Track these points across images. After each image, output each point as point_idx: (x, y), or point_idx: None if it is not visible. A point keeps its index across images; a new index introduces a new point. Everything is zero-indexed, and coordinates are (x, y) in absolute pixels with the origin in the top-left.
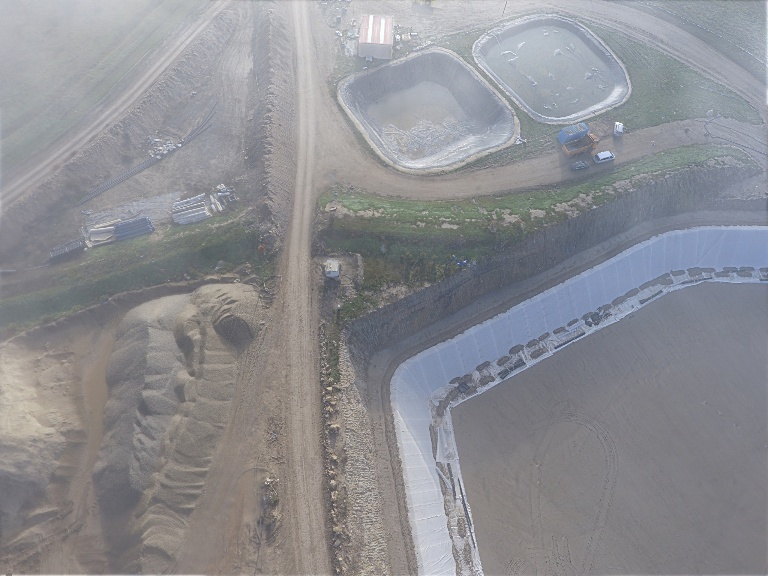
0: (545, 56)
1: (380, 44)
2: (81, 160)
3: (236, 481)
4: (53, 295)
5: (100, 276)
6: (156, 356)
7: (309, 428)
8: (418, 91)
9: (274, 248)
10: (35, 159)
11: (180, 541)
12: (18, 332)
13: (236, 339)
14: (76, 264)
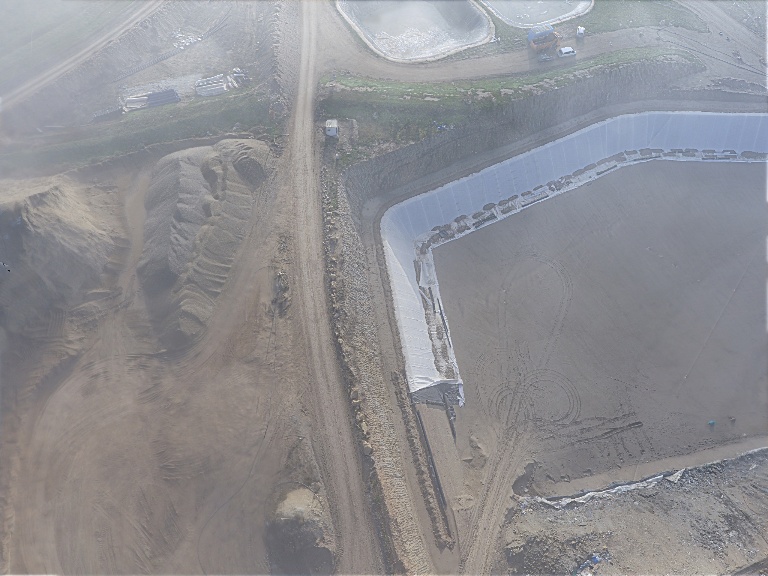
0: None
1: None
2: (117, 45)
3: (254, 275)
4: (99, 142)
5: (137, 130)
6: (187, 181)
7: (313, 240)
8: (407, 6)
9: (282, 114)
10: (76, 47)
11: (209, 314)
12: (71, 168)
13: (252, 177)
14: (116, 121)
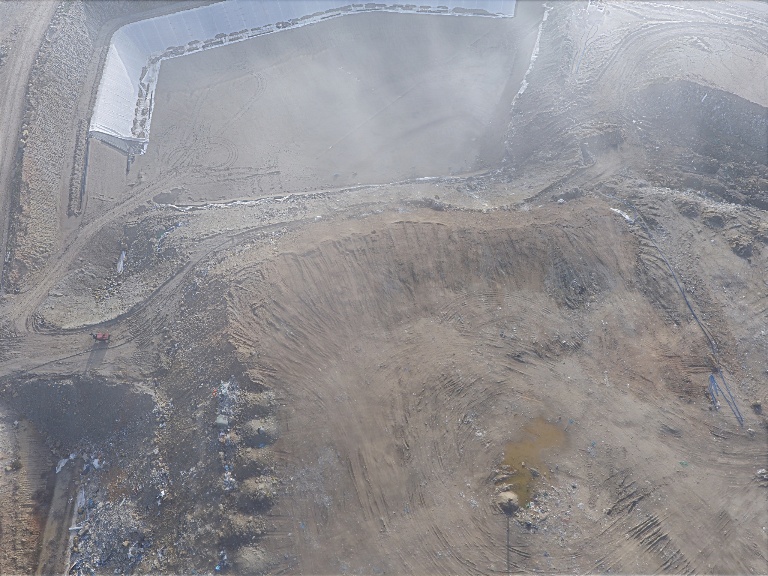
0: None
1: None
2: None
3: None
4: None
5: None
6: None
7: (39, 29)
8: None
9: None
10: None
11: None
12: None
13: None
14: None
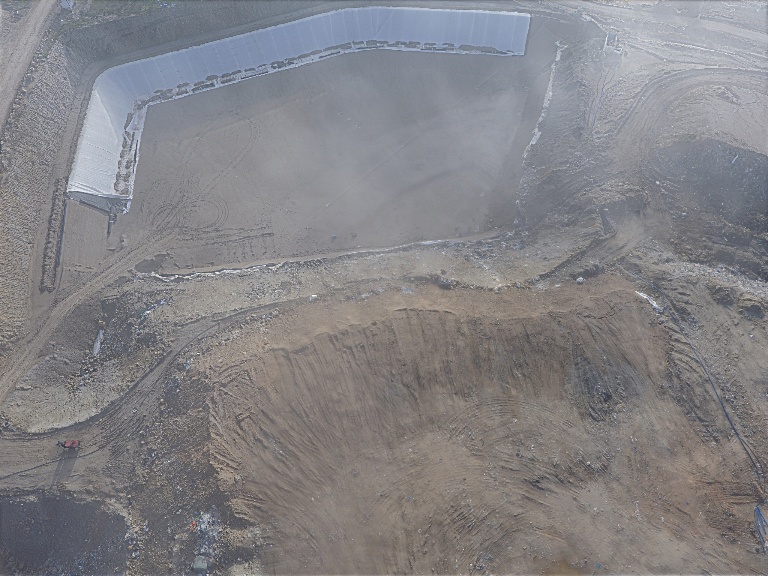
0: None
1: None
2: None
3: None
4: None
5: None
6: None
7: (14, 77)
8: None
9: None
10: None
11: None
12: None
13: None
14: None
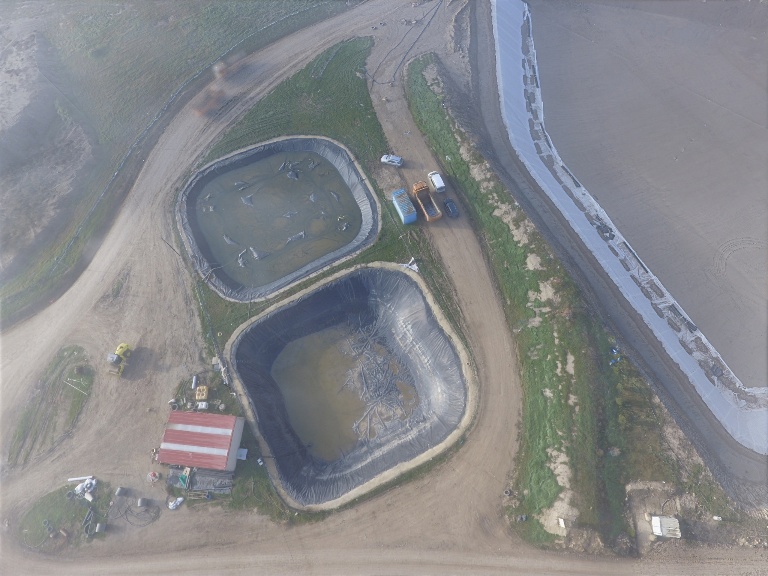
0: (252, 216)
1: (232, 435)
2: None
3: None
4: None
5: None
6: None
7: None
8: (289, 384)
9: None
10: None
11: None
12: None
13: None
14: None
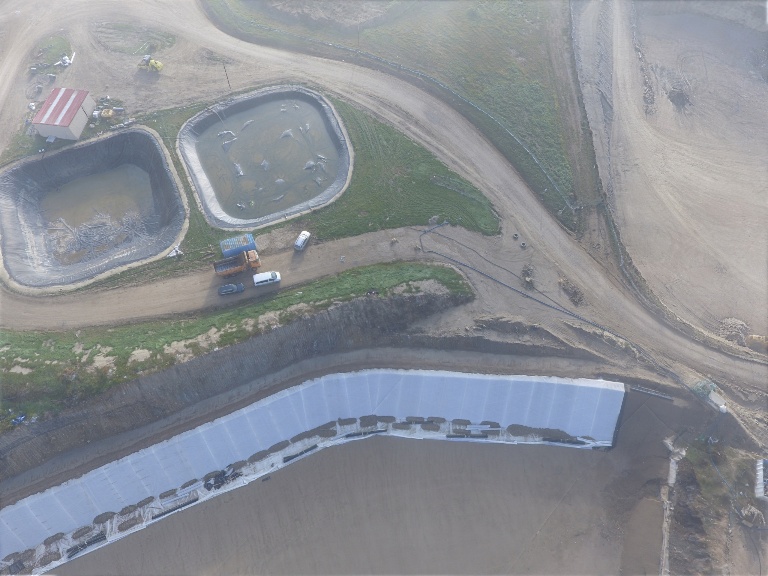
0: (269, 138)
1: (54, 125)
2: None
3: None
4: None
5: None
6: None
7: None
8: (113, 176)
9: None
10: None
11: None
12: None
13: None
14: None
